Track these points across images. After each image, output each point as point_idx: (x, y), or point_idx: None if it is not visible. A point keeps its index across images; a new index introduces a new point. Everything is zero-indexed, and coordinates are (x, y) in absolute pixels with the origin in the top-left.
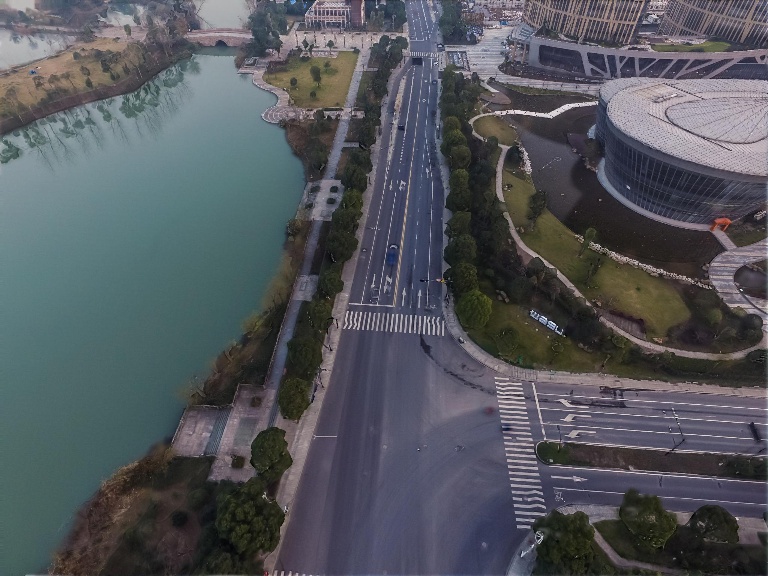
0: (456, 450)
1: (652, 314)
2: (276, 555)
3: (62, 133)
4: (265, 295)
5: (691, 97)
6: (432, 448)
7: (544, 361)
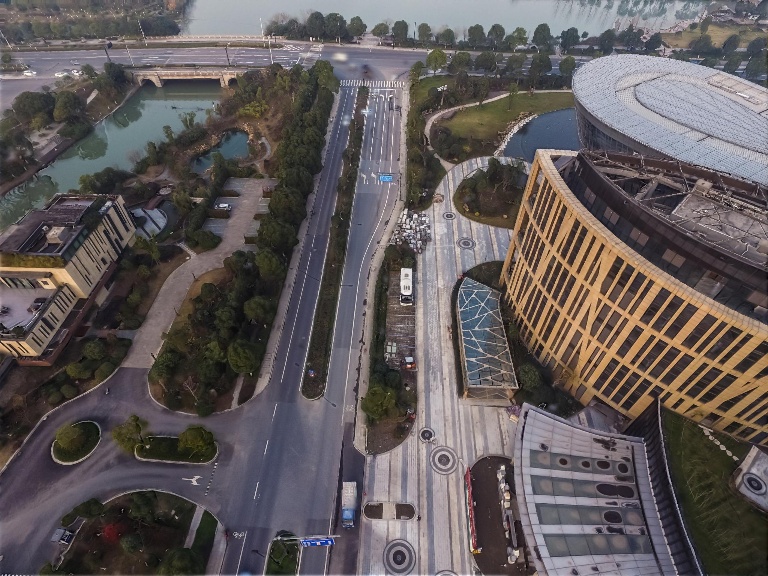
0: (365, 71)
1: (458, 124)
2: (328, 45)
3: (578, 1)
4: (438, 28)
5: (754, 106)
6: (366, 67)
7: (415, 92)
